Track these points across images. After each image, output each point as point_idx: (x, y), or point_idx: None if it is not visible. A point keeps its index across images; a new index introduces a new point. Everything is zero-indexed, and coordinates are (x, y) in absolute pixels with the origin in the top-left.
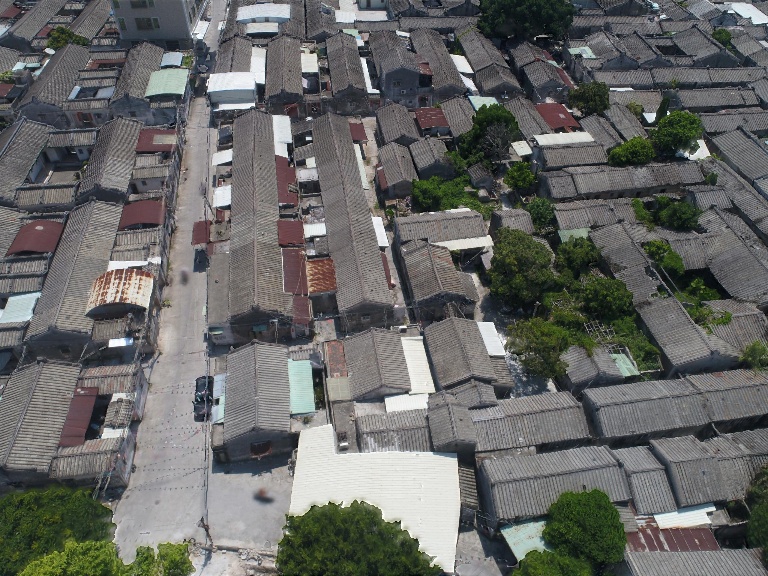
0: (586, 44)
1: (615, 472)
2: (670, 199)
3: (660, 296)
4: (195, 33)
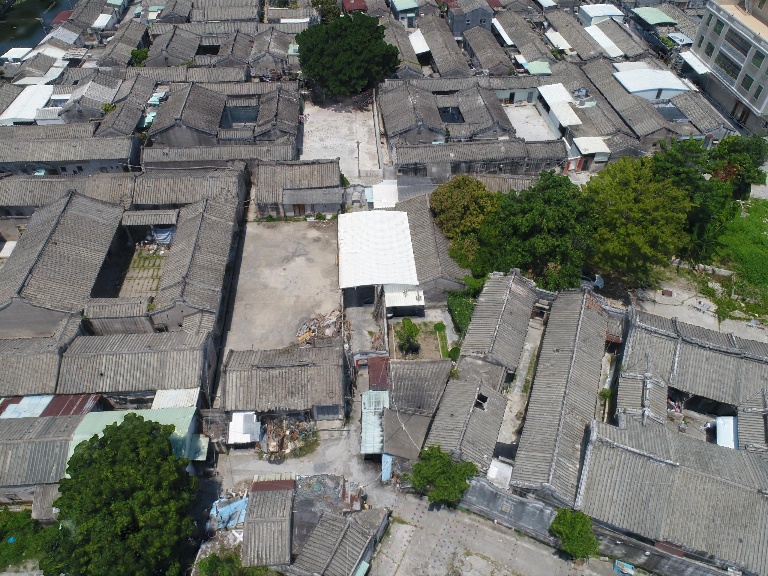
0: None
1: None
2: None
3: None
4: (682, 40)
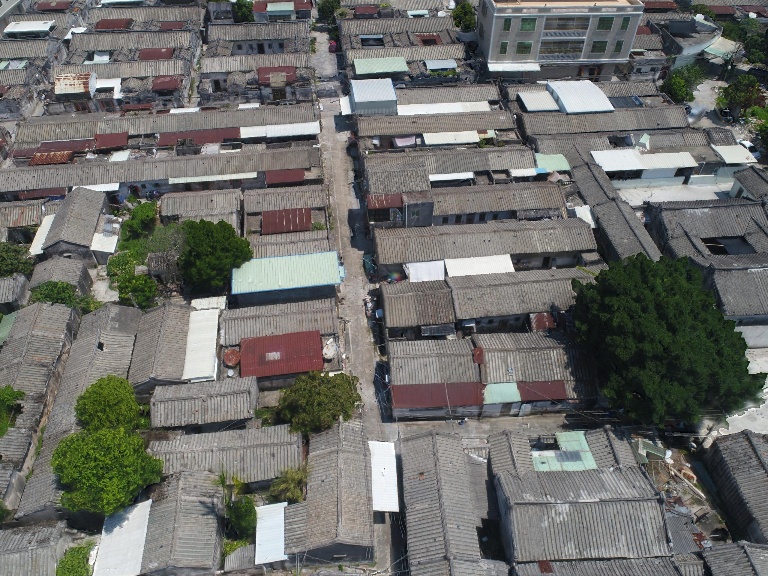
0: (607, 466)
1: None
2: None
3: None
4: (480, 59)
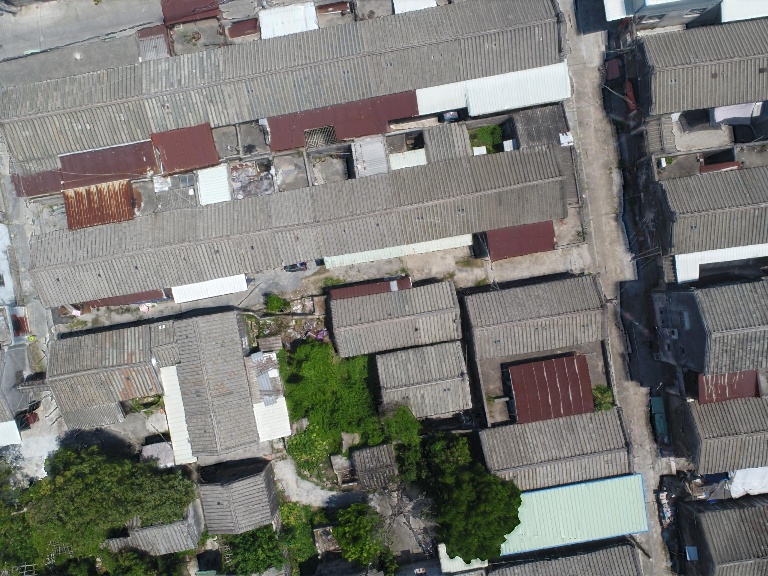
0: None
1: None
2: None
3: None
4: None
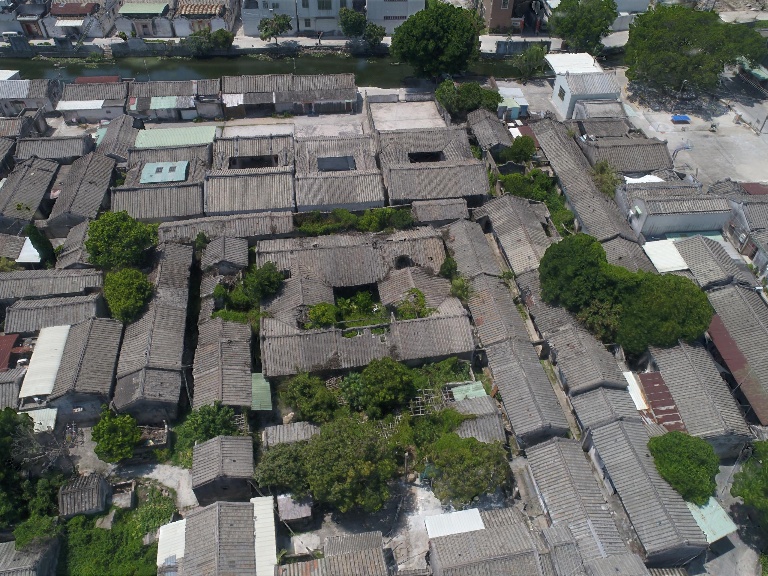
0: None
1: (626, 425)
2: (221, 284)
3: (386, 335)
4: None
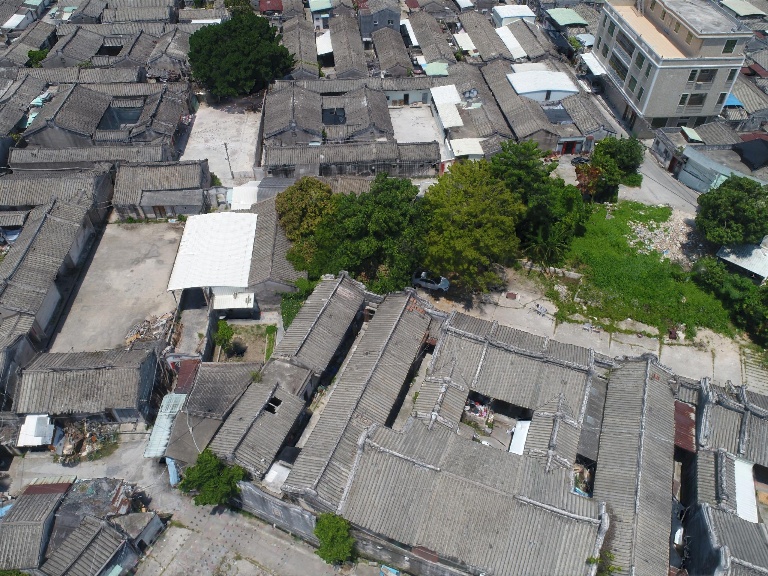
0: None
1: None
2: None
3: None
4: (584, 41)
